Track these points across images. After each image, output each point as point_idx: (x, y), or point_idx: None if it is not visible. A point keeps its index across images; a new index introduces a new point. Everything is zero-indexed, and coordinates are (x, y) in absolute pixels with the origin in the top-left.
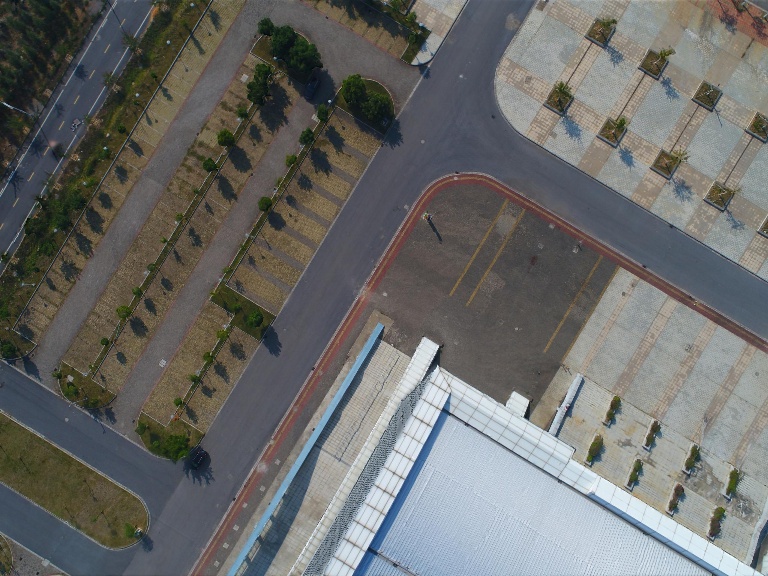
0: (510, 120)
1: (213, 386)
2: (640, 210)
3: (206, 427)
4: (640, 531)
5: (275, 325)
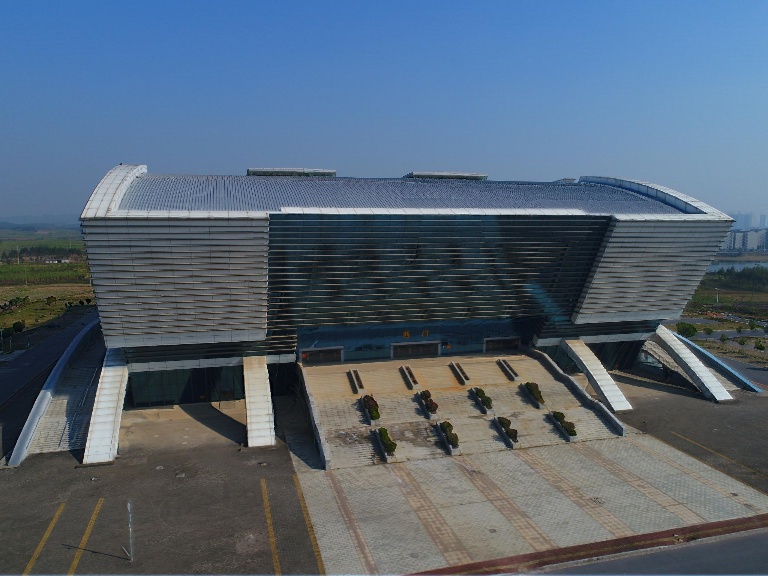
0: None
1: None
2: None
3: None
4: None
5: None
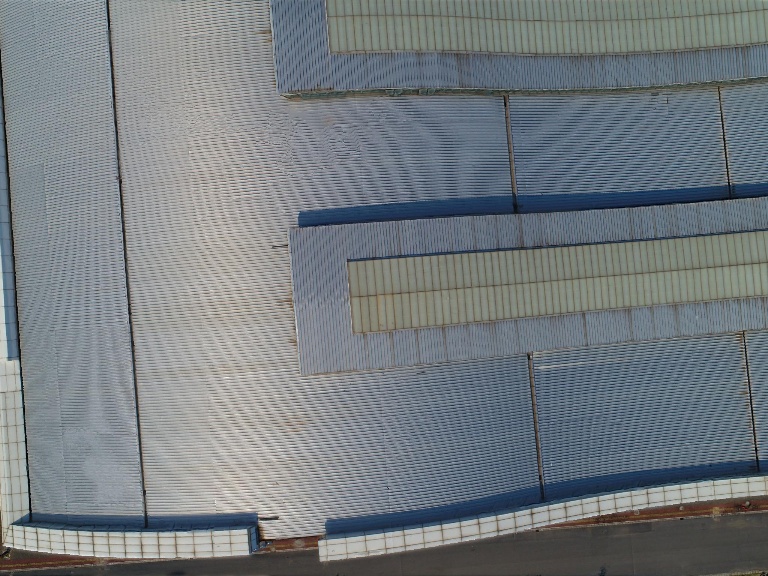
0: None
1: None
2: None
3: None
4: None
5: None
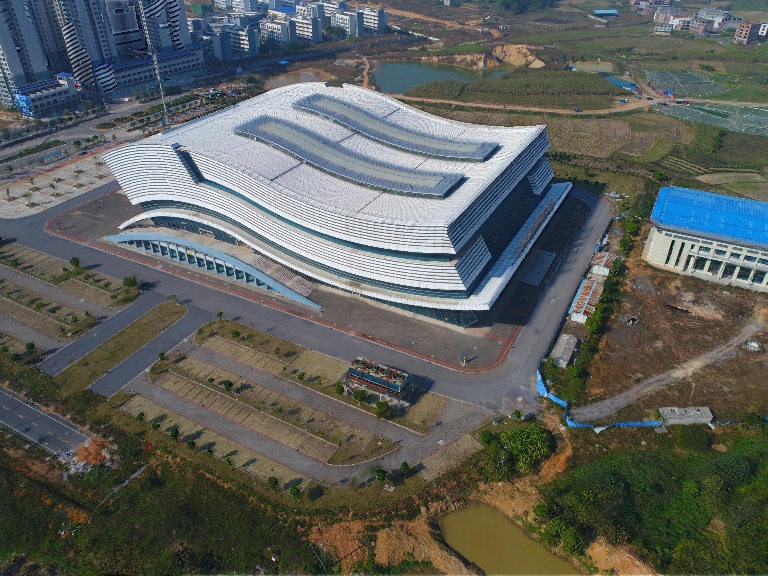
0: (31, 215)
1: None
2: (94, 190)
3: None
4: None
5: (84, 266)
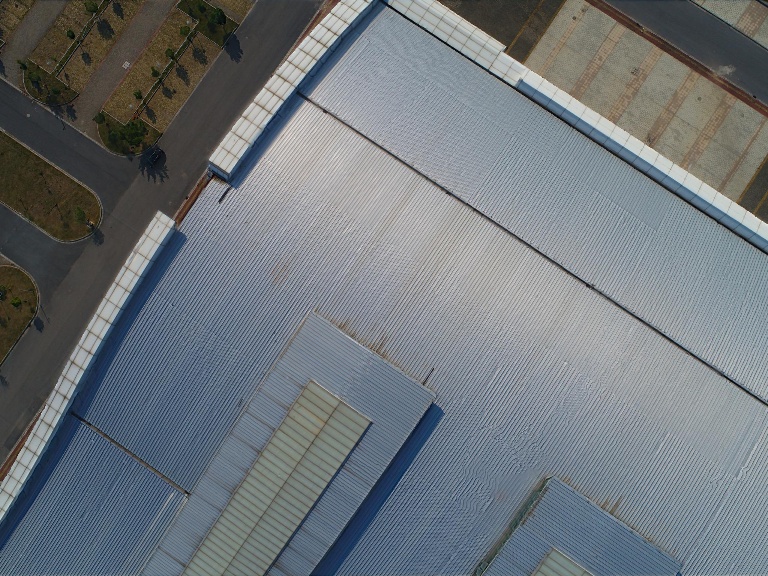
0: None
1: (173, 88)
2: None
3: (164, 127)
4: (566, 123)
5: (238, 33)
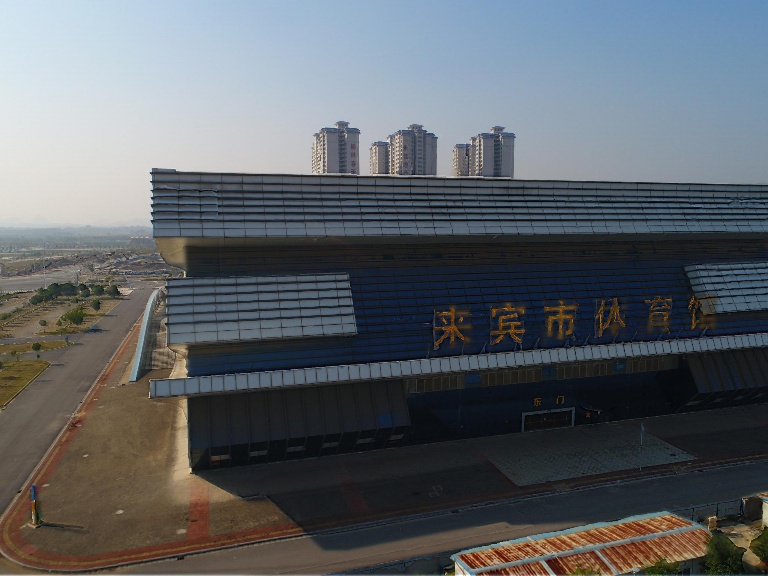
0: None
1: None
2: None
3: None
4: None
5: None
